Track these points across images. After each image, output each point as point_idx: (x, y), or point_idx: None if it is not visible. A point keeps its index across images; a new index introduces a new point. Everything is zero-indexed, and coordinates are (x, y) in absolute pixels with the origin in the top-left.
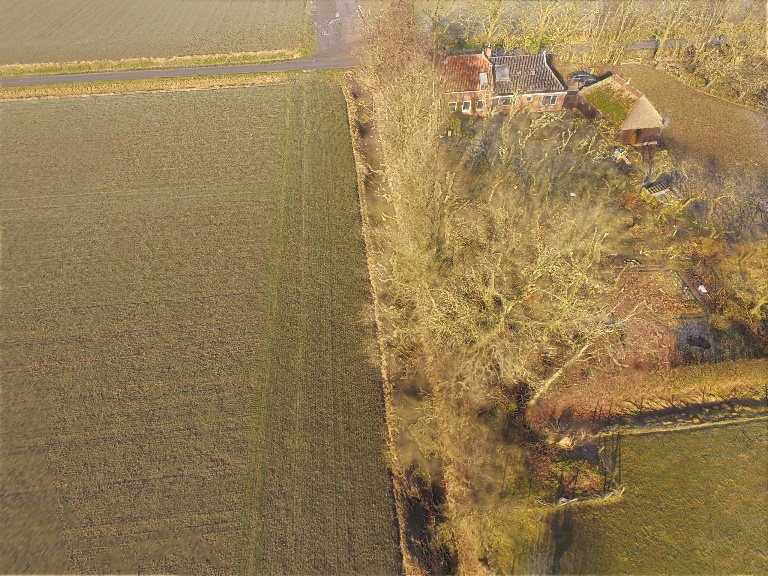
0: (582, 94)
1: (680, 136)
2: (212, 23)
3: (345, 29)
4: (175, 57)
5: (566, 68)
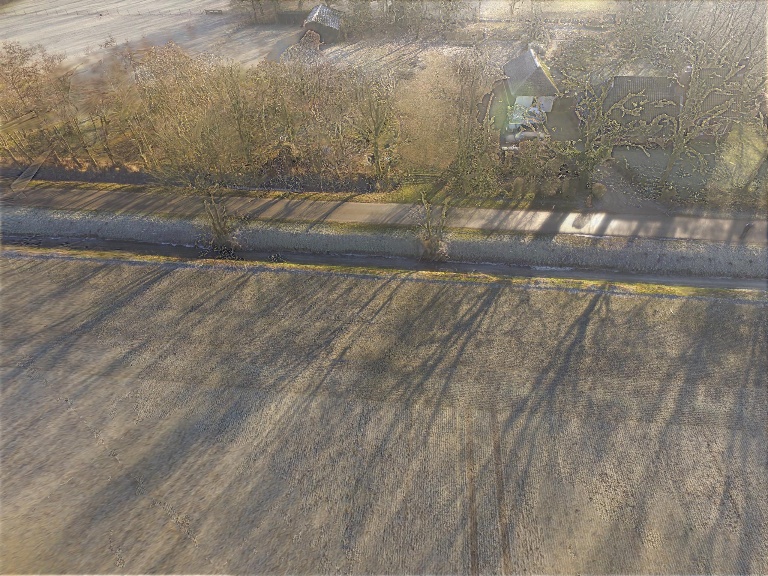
0: None
1: None
2: None
3: None
4: None
5: None
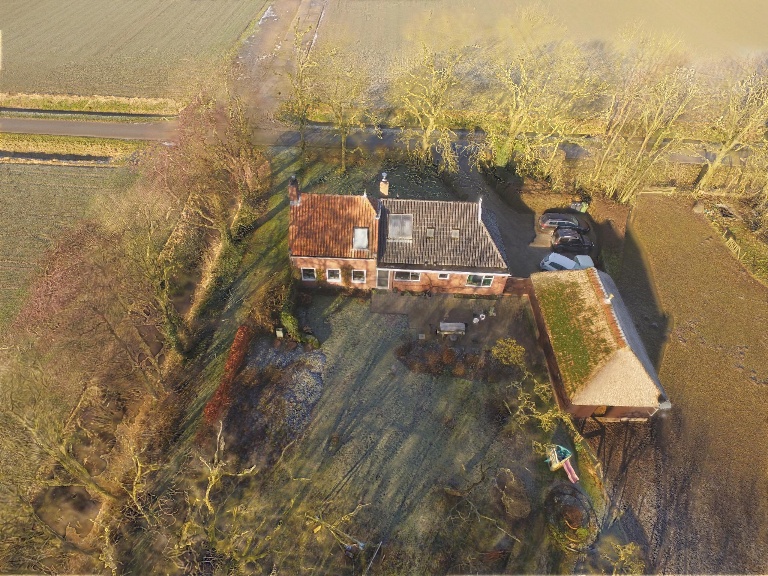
0: (535, 283)
1: (697, 404)
2: (113, 42)
3: (271, 73)
4: (20, 94)
5: (540, 201)
